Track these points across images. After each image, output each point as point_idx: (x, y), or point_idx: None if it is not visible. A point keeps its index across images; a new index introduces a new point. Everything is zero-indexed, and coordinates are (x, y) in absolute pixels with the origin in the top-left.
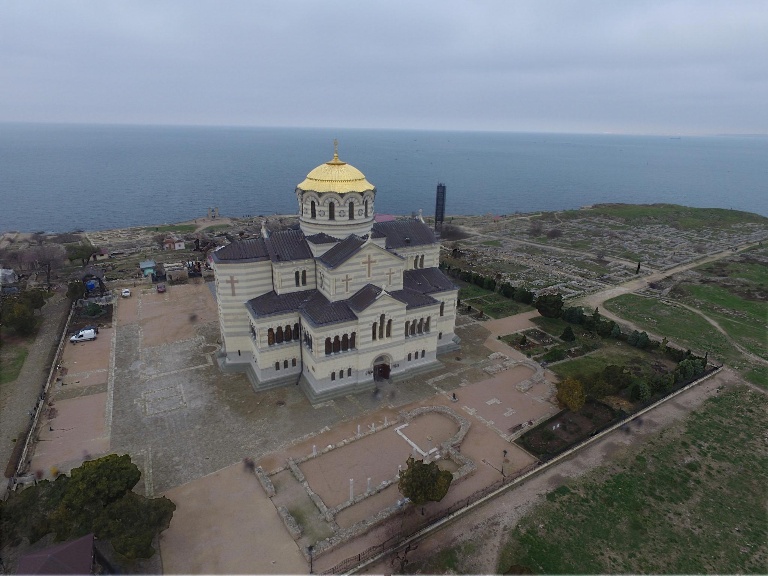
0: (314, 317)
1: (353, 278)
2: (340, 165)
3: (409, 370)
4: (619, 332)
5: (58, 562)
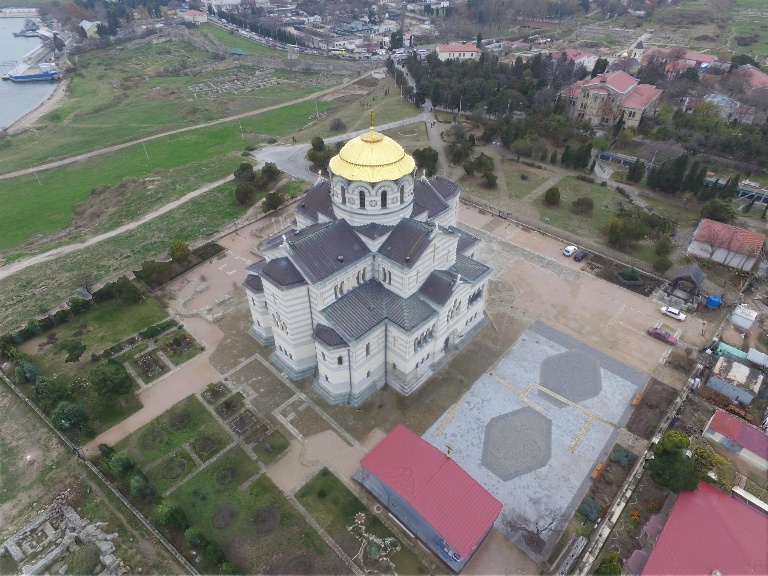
0: None
1: None
2: None
3: None
4: None
5: None
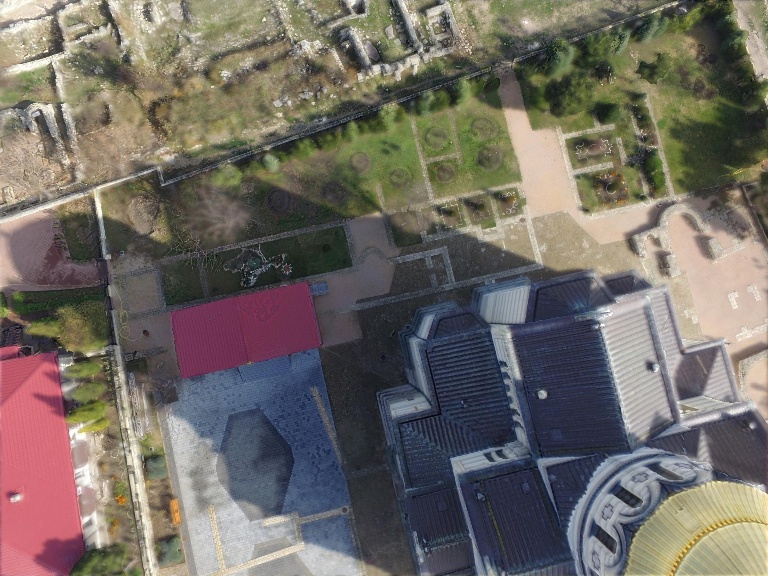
0: None
1: None
2: None
3: None
4: None
5: None
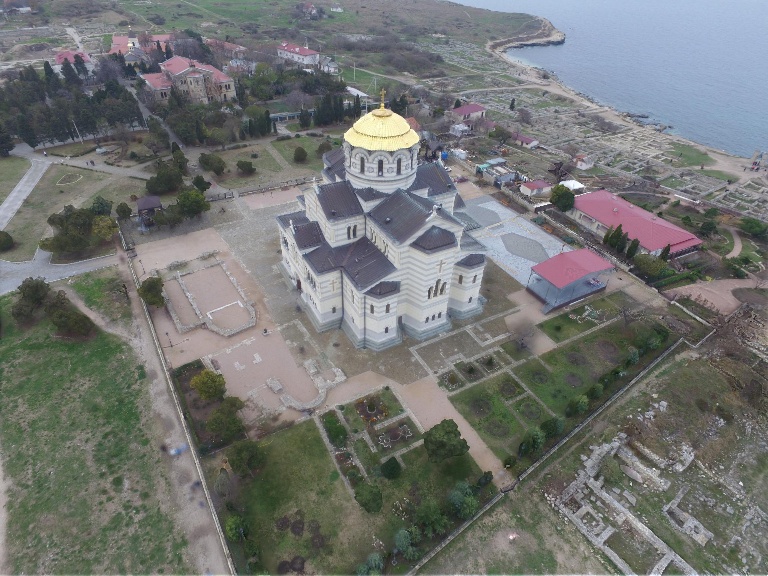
0: None
1: (311, 208)
2: (373, 115)
3: (308, 306)
4: (404, 552)
5: (144, 200)
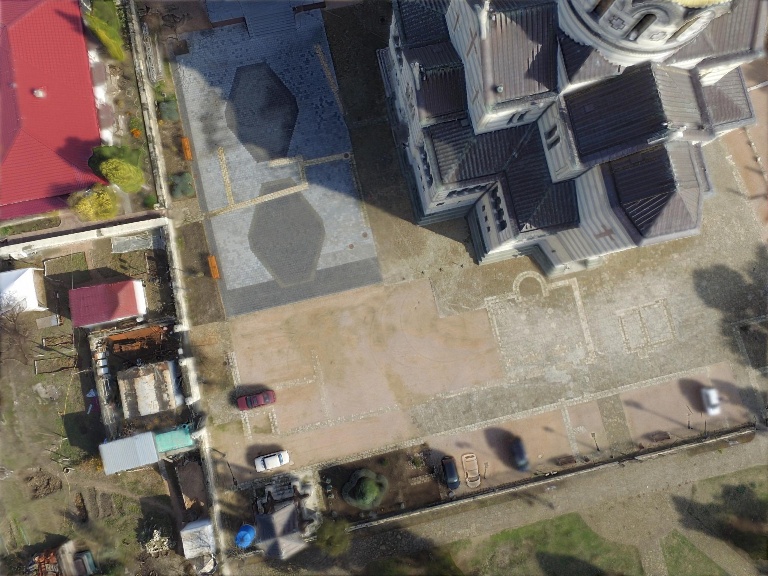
0: (734, 117)
1: None
2: None
3: None
4: None
5: None
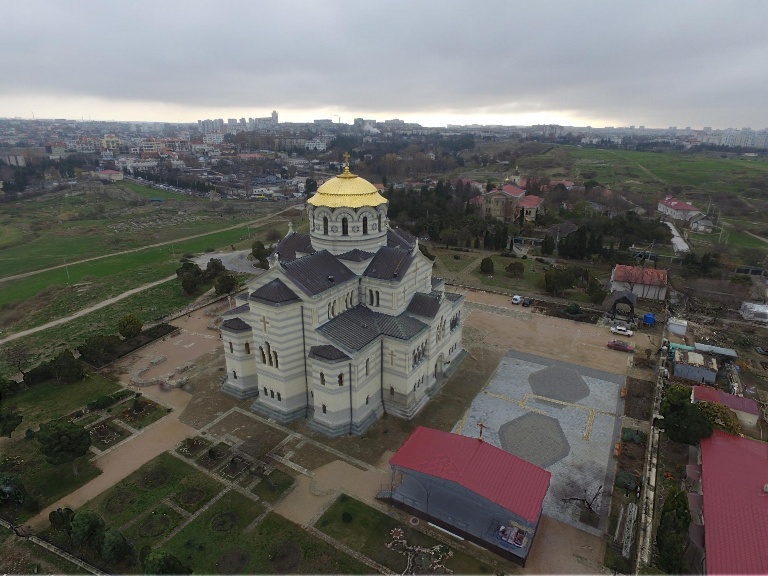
0: None
1: None
2: None
3: None
4: None
5: None
